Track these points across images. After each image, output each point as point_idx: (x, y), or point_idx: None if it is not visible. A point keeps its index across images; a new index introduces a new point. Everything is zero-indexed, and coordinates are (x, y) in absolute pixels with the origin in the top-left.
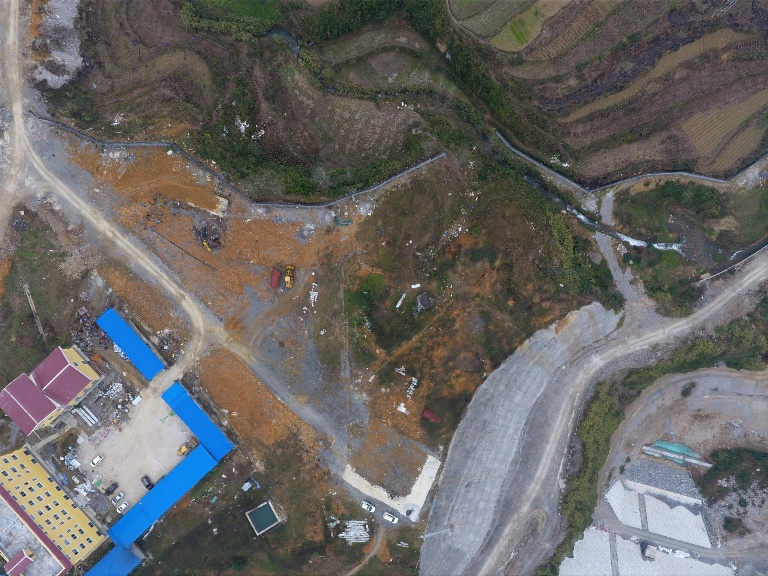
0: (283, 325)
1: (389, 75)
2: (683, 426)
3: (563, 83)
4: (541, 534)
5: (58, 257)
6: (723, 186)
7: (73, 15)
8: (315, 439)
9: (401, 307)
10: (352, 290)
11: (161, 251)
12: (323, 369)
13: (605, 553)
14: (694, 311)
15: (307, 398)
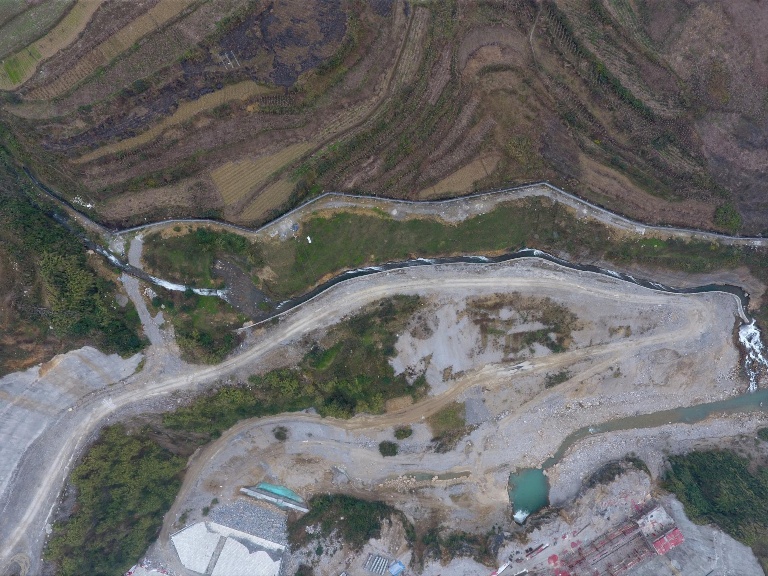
0: None
1: None
2: (282, 470)
3: (69, 124)
4: None
5: None
6: (254, 236)
7: None
8: None
9: None
10: None
11: None
12: None
13: None
14: (226, 359)
15: None
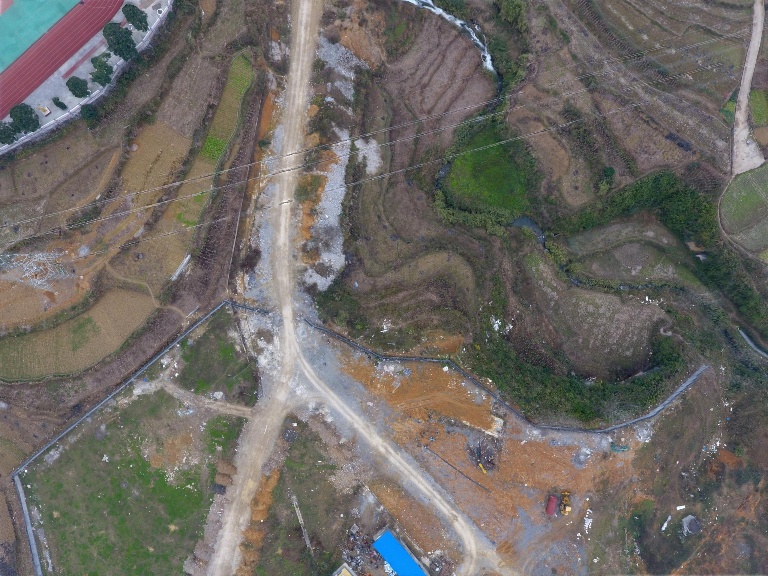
0: (556, 551)
1: (633, 267)
2: None
3: None
4: None
5: (328, 469)
6: None
7: (338, 212)
8: None
9: (667, 530)
10: (626, 518)
11: (434, 469)
12: None
13: None
14: None
15: None
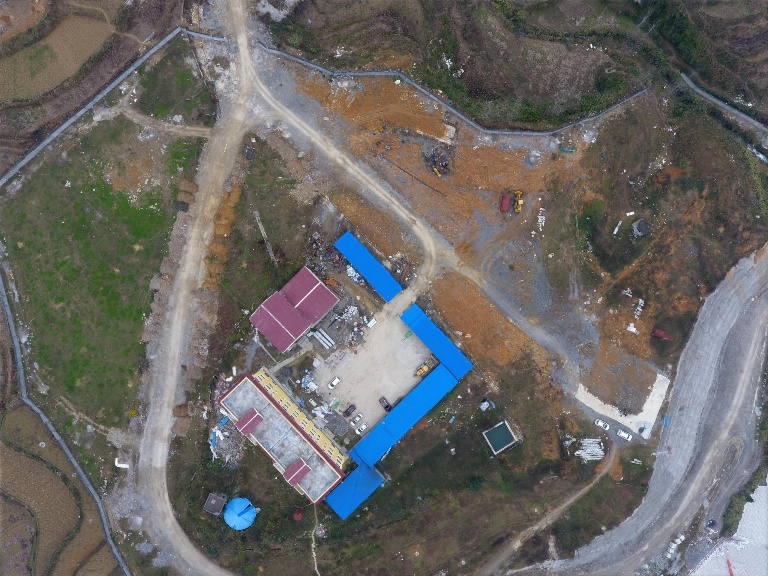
0: (512, 249)
1: (577, 19)
2: None
3: (754, 23)
4: (738, 461)
5: (288, 184)
6: None
7: None
8: (548, 359)
9: (618, 234)
10: (578, 215)
11: (391, 177)
12: (553, 291)
13: None
14: None
15: (538, 320)
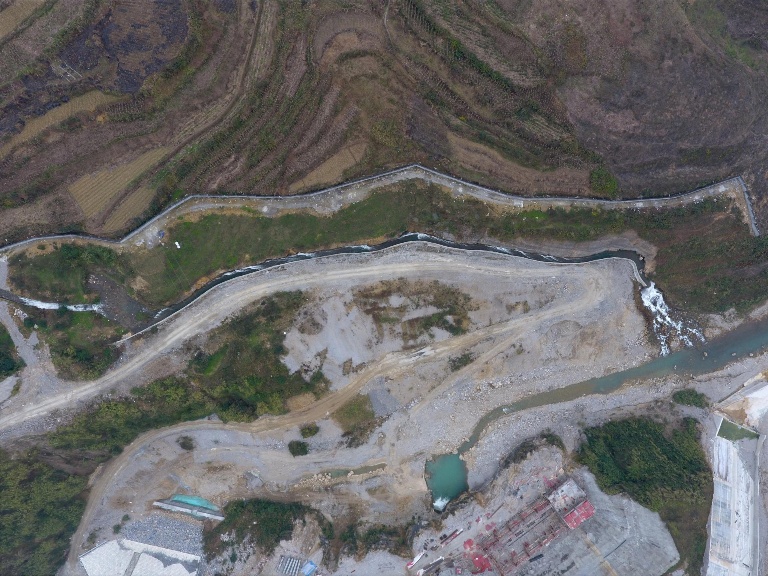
0: None
1: None
2: (193, 480)
3: None
4: None
5: None
6: (120, 247)
7: None
8: None
9: None
10: None
11: None
12: None
13: None
14: (106, 373)
15: None
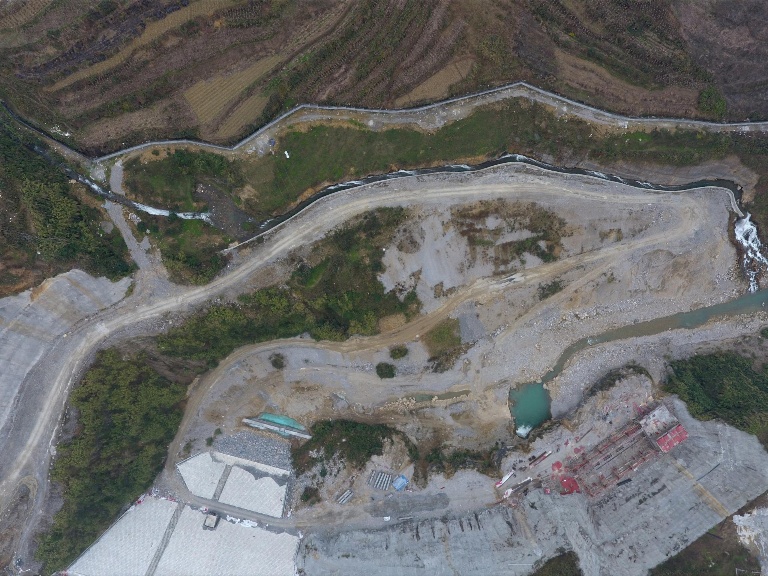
0: None
1: None
2: (281, 398)
3: (40, 52)
4: (34, 501)
5: None
6: (232, 154)
7: None
8: None
9: None
10: None
11: None
12: None
13: (163, 523)
14: (214, 279)
15: None
